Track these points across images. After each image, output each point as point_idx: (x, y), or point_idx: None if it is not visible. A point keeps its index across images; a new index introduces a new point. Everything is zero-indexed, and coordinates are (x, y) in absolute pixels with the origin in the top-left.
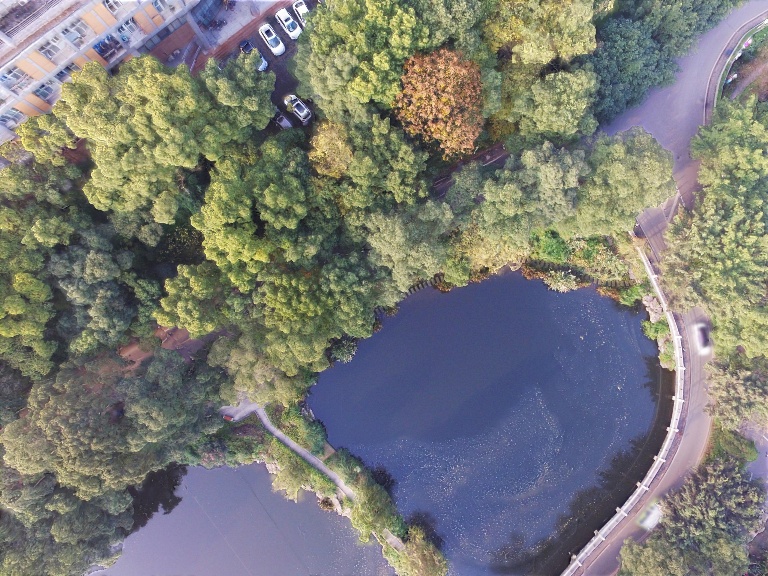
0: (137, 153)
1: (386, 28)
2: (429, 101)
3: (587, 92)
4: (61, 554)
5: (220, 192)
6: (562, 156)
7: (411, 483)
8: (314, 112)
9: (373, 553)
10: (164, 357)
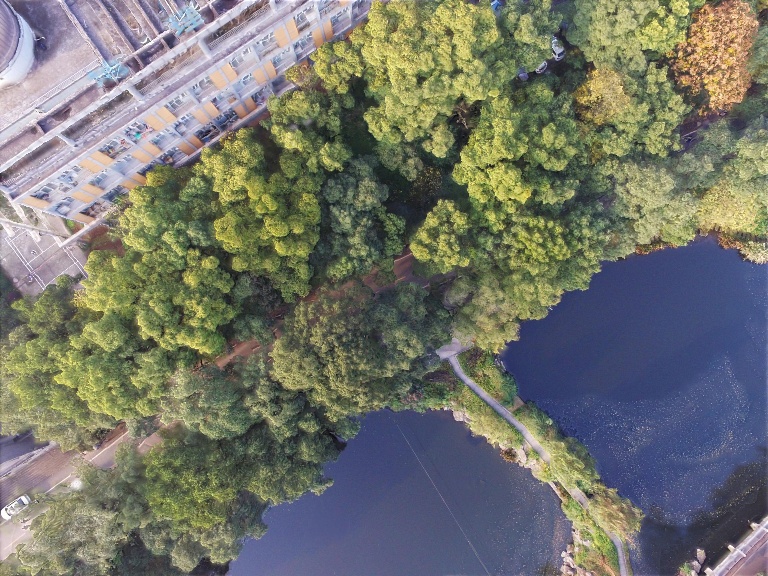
0: (436, 82)
1: None
2: (713, 51)
3: None
4: (303, 472)
5: (506, 127)
6: None
7: (596, 440)
8: (564, 61)
9: (551, 506)
10: (415, 289)
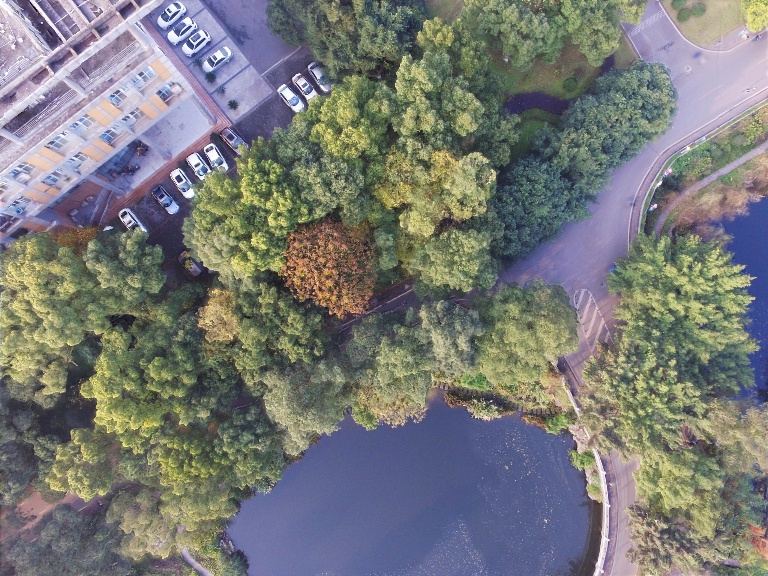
0: (18, 336)
1: None
2: (312, 273)
3: (483, 249)
4: None
5: (103, 369)
6: (455, 318)
7: None
8: None
9: None
10: (59, 519)
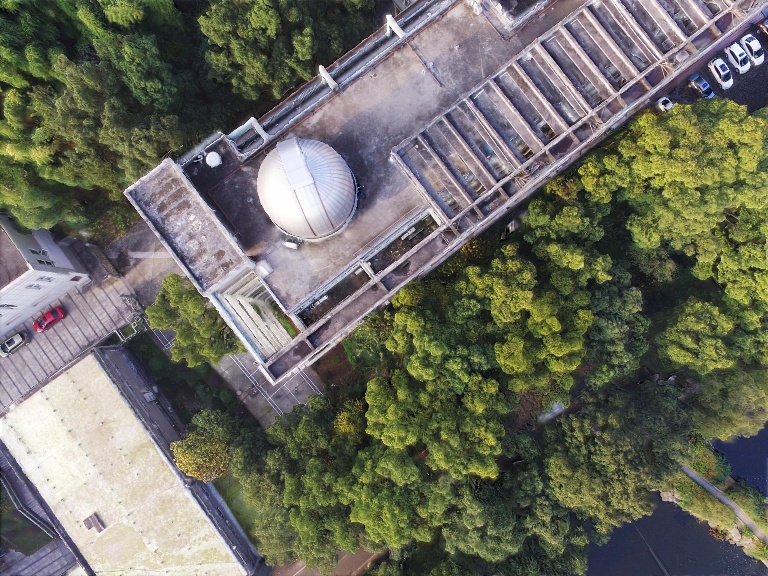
0: (720, 195)
1: None
2: None
3: None
4: None
5: None
6: None
7: None
8: None
9: None
10: None
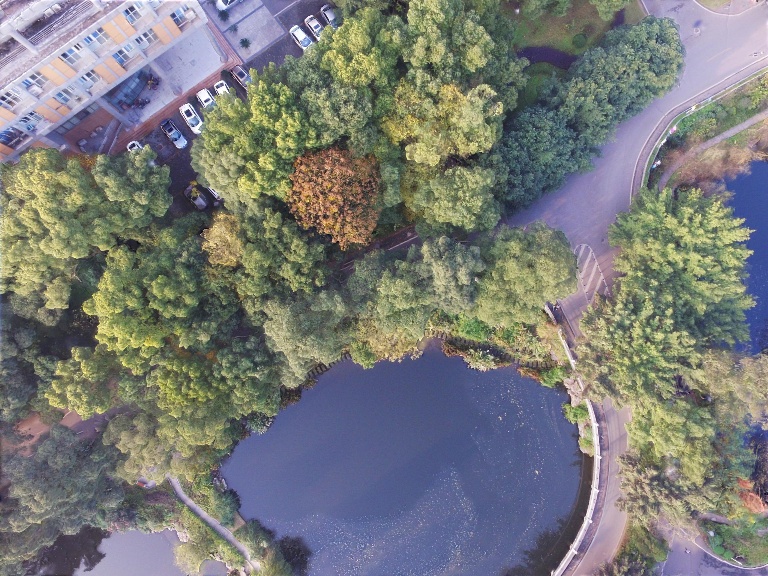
0: (24, 245)
1: (272, 130)
2: (317, 199)
3: (487, 187)
4: None
5: (106, 283)
6: (457, 252)
7: (320, 559)
8: None
9: None
10: (56, 436)
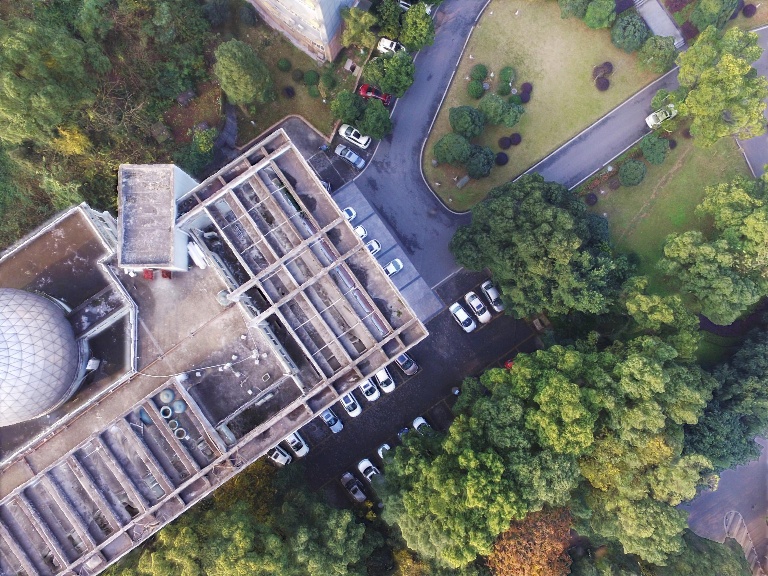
0: None
1: (485, 508)
2: (521, 564)
3: None
4: None
5: None
6: None
7: None
8: None
9: None
10: None
